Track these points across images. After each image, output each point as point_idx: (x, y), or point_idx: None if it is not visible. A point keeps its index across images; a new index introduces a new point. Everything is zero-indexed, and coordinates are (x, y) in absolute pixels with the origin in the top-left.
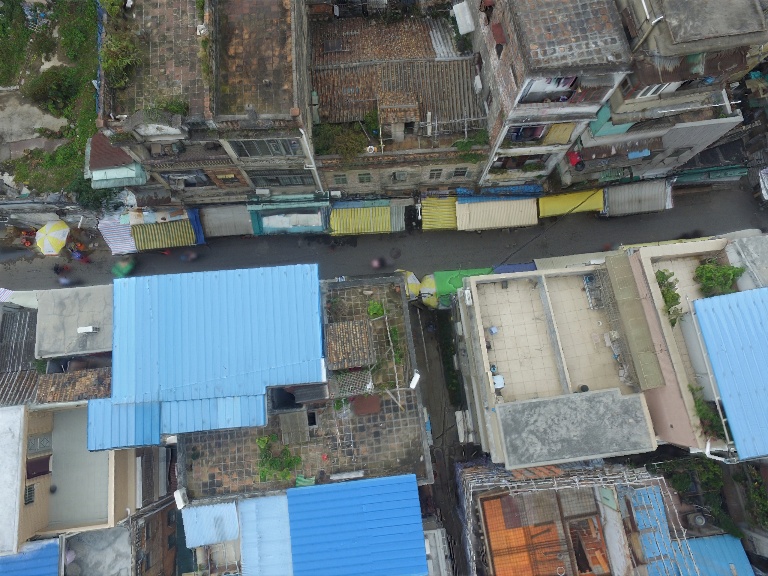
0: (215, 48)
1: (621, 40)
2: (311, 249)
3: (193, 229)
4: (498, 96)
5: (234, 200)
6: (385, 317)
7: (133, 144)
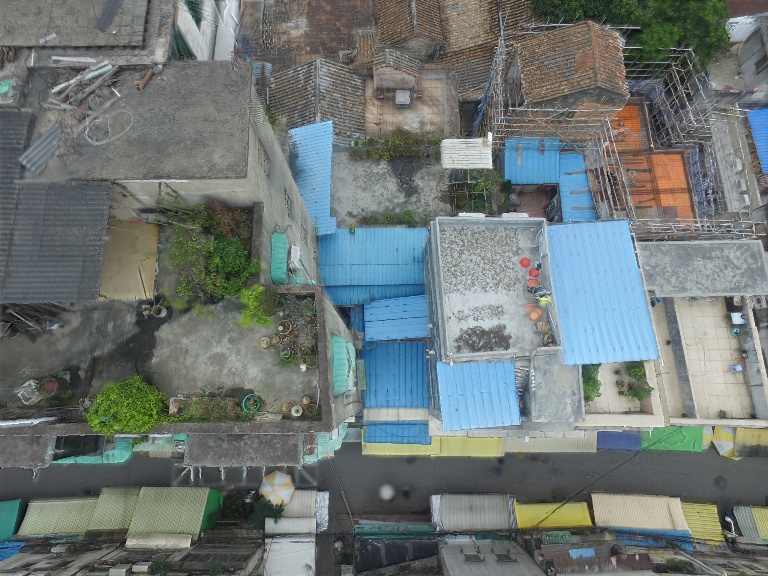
0: None
1: None
2: None
3: None
4: None
5: None
6: None
7: None
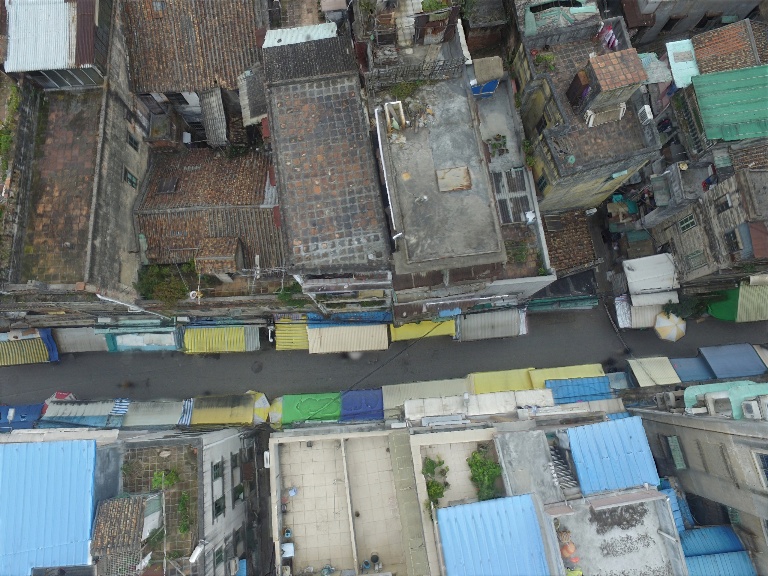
0: (21, 208)
1: (383, 238)
2: (174, 360)
3: (46, 347)
4: None
5: (81, 323)
6: (162, 493)
7: None
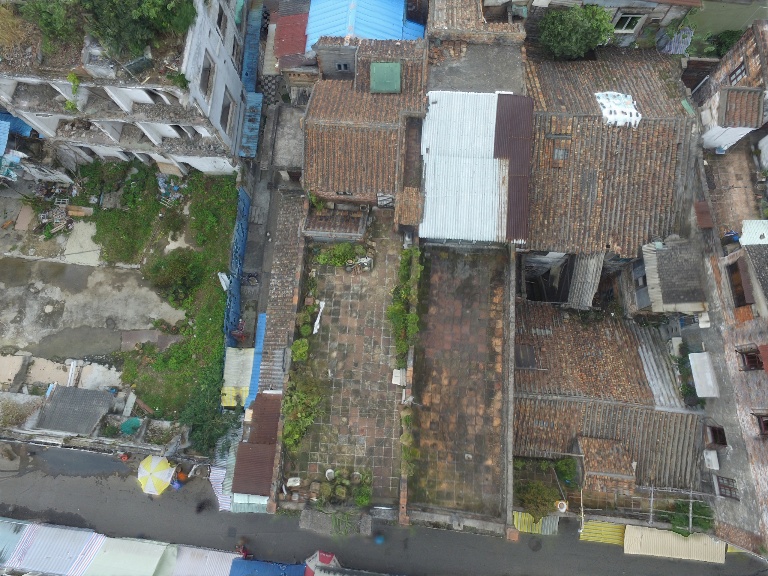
0: None
1: None
2: None
3: None
4: (757, 516)
5: None
6: None
7: None
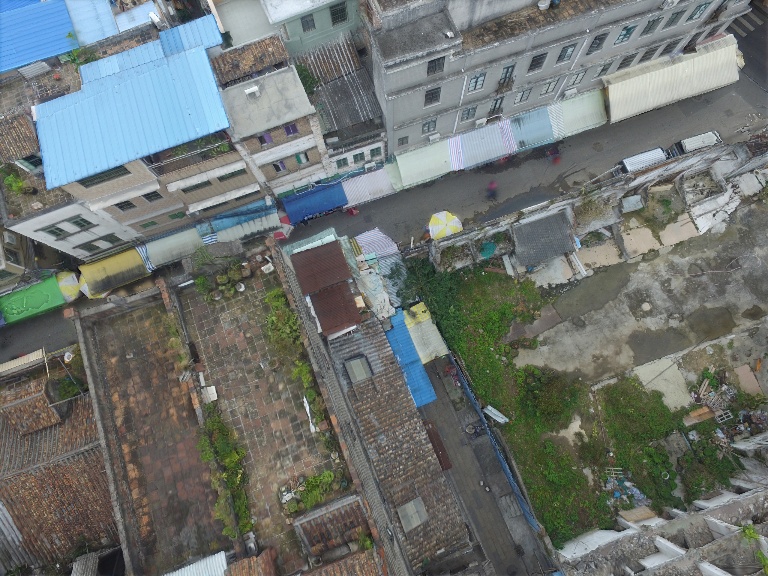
0: None
1: None
2: None
3: None
4: None
5: None
6: None
7: (253, 247)
